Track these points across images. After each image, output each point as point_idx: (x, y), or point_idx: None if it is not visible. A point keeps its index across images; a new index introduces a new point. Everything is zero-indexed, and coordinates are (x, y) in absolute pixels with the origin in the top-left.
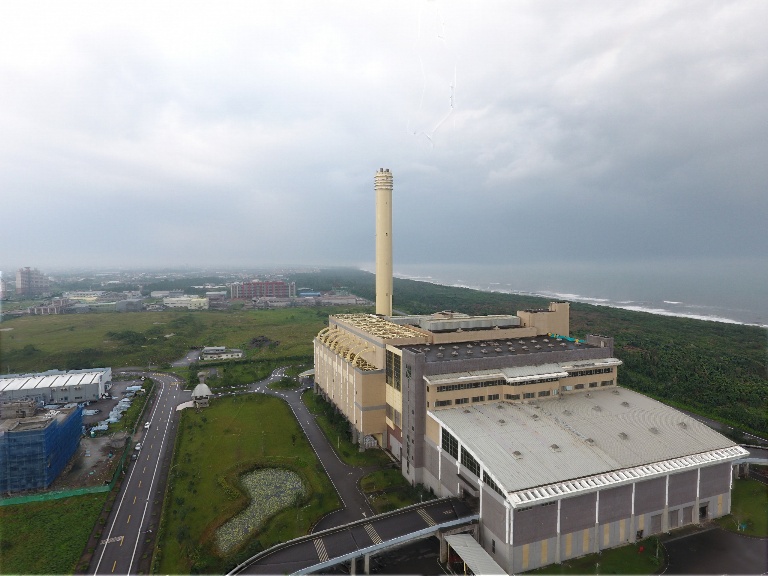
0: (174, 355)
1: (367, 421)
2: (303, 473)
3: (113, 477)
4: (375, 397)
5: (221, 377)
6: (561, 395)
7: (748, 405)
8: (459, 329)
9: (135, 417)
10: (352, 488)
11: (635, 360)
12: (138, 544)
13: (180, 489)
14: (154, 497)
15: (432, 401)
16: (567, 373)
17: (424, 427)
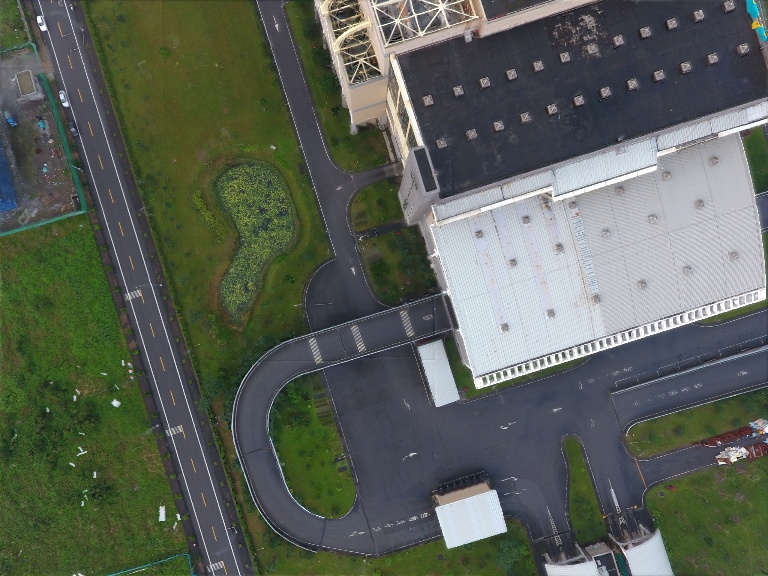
0: None
1: (359, 117)
2: (286, 188)
3: (75, 186)
4: (370, 99)
5: None
6: None
7: None
8: None
9: None
10: (342, 221)
11: None
12: (158, 302)
13: (159, 211)
14: (138, 224)
15: None
16: (655, 169)
17: (426, 214)
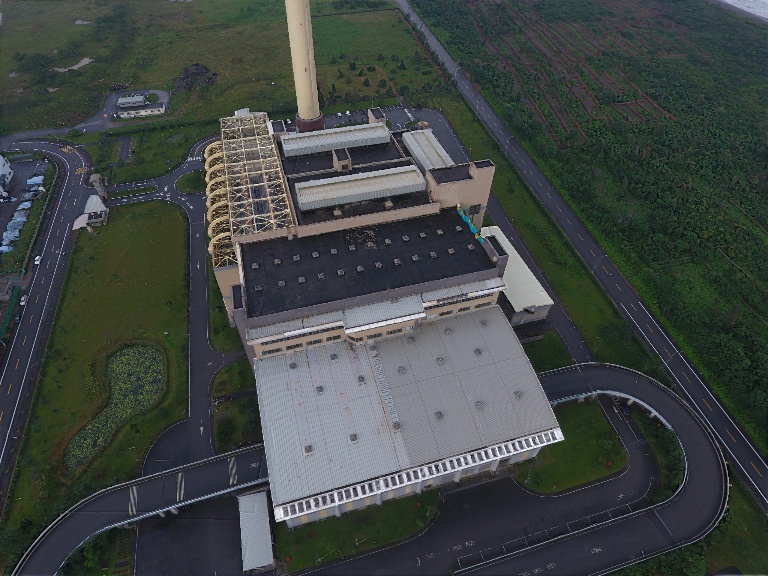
0: (87, 108)
1: None
2: (165, 361)
3: None
4: None
5: (131, 161)
6: (419, 326)
7: (691, 259)
8: (336, 210)
9: (27, 245)
10: (204, 388)
11: (616, 157)
12: (4, 454)
13: (51, 376)
14: (27, 386)
15: (257, 352)
16: (424, 315)
17: None
